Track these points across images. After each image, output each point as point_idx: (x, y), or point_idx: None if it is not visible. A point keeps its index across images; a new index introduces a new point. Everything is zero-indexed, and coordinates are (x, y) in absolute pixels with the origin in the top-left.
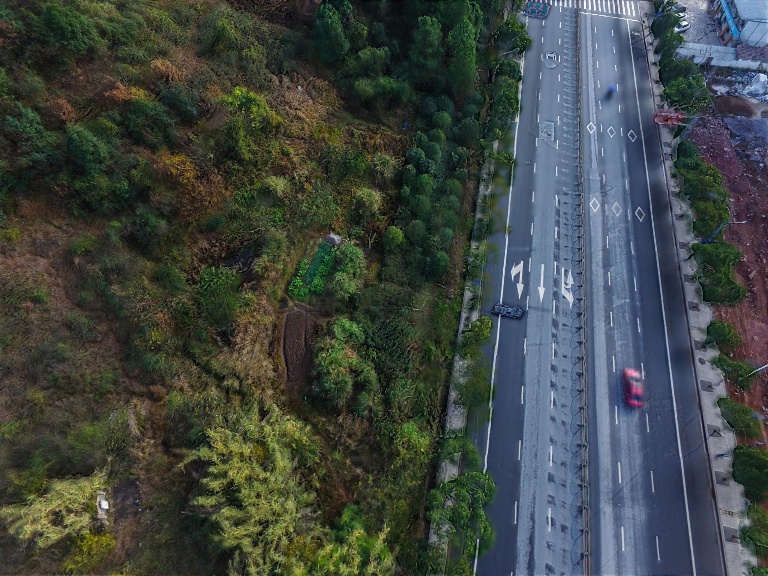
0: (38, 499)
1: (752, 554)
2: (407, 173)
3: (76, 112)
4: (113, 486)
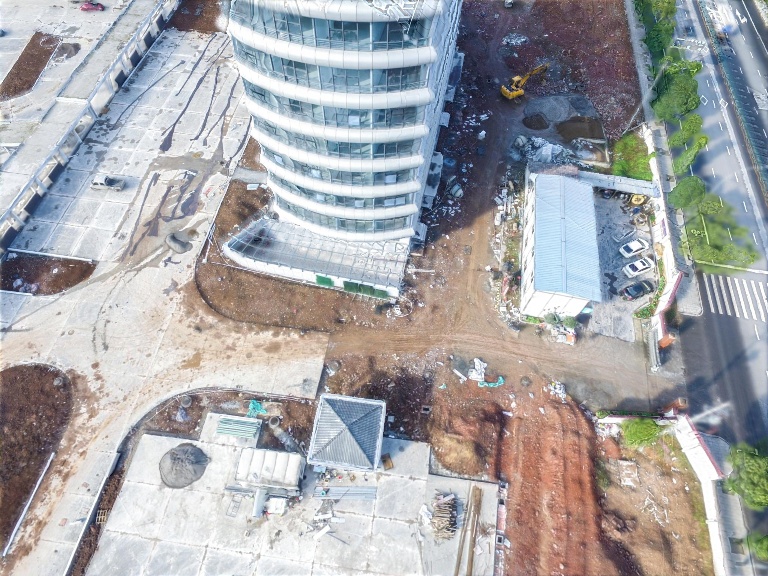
0: None
1: None
2: None
3: None
4: None
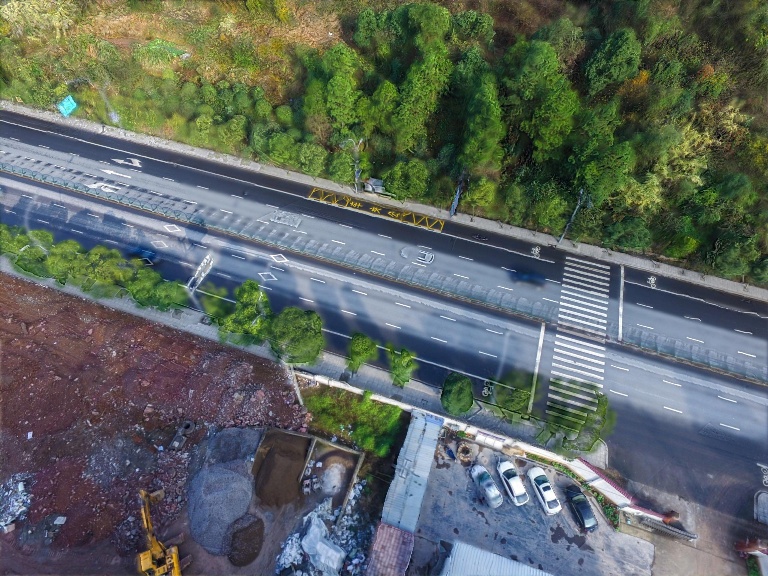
0: None
1: None
2: None
3: None
4: None
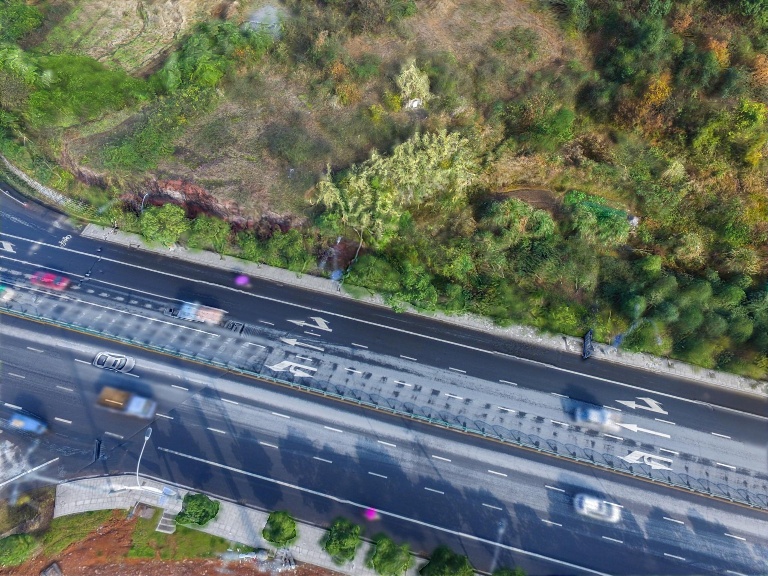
0: (418, 69)
1: (368, 575)
2: (738, 277)
3: (686, 31)
4: (425, 108)
